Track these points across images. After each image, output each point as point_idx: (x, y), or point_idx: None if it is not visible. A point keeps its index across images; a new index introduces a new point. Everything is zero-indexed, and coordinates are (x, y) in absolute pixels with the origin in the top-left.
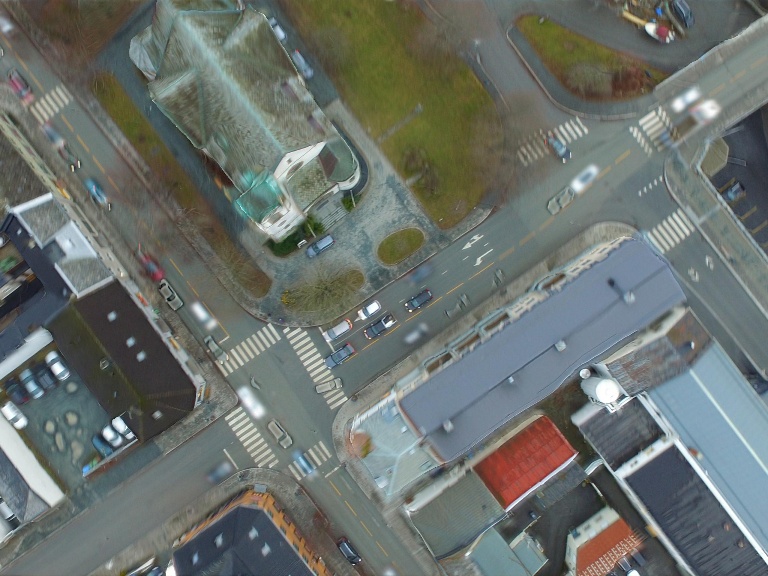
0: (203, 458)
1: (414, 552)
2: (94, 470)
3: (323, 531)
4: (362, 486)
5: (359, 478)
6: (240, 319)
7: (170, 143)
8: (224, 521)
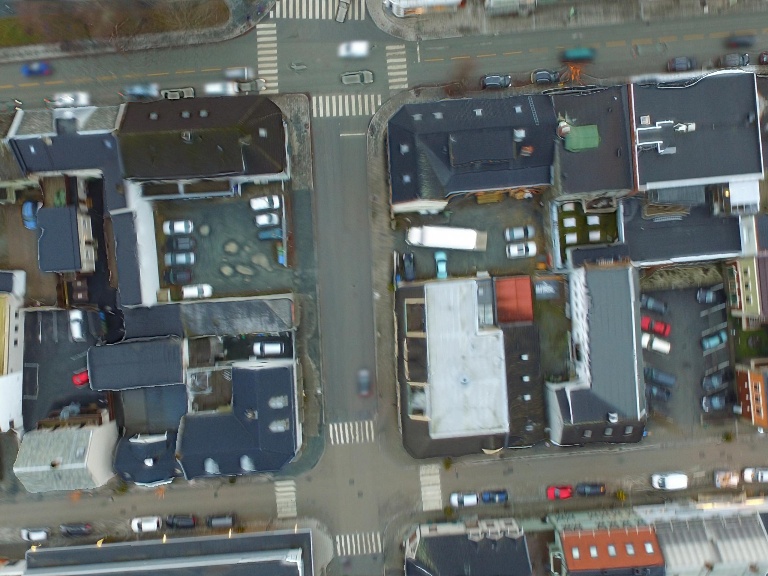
0: (336, 158)
1: (533, 27)
2: (286, 252)
3: (464, 92)
4: (447, 36)
5: (439, 34)
6: (237, 48)
7: (47, 8)
8: (392, 140)
